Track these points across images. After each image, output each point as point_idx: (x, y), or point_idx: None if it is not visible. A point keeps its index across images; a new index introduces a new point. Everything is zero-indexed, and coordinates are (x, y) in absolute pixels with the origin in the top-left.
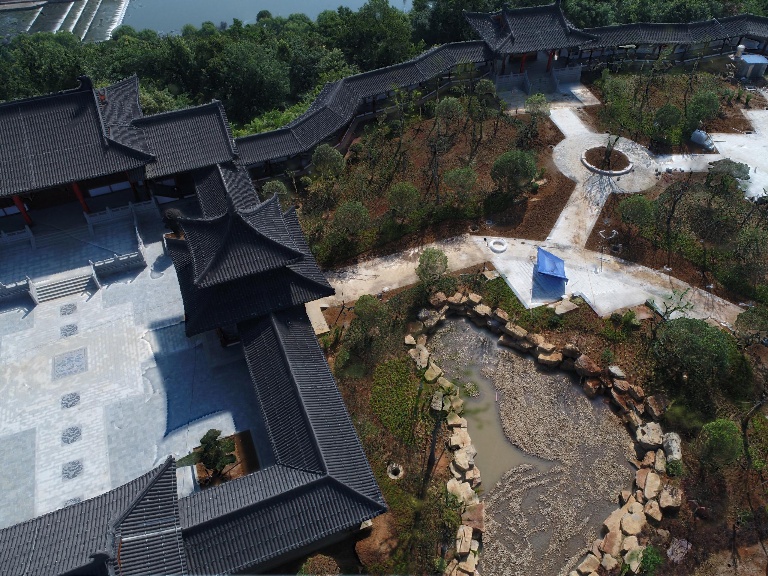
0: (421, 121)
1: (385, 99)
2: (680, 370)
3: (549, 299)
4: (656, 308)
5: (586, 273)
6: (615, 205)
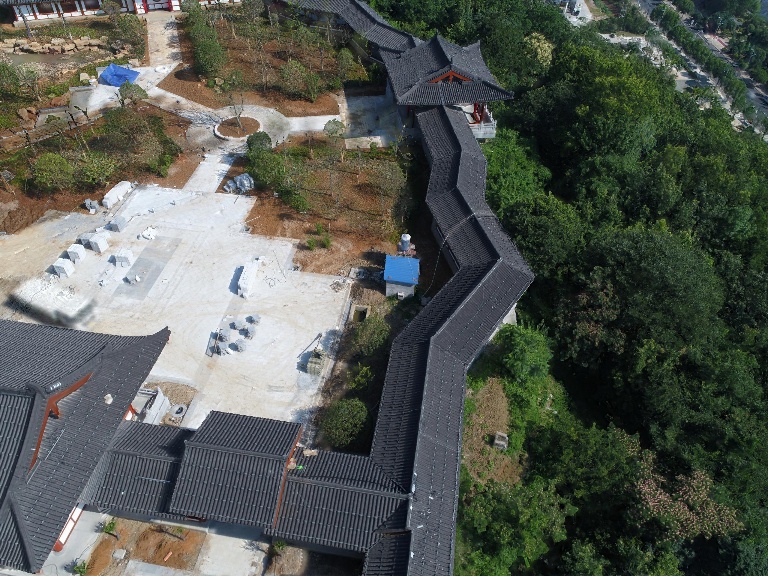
0: (332, 54)
1: (374, 44)
2: (6, 101)
3: (101, 79)
4: (34, 76)
5: (112, 94)
6: (173, 118)
